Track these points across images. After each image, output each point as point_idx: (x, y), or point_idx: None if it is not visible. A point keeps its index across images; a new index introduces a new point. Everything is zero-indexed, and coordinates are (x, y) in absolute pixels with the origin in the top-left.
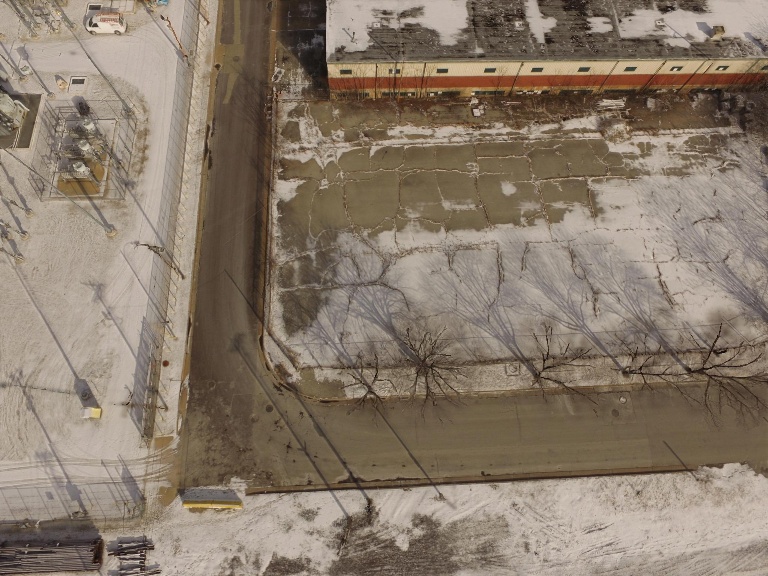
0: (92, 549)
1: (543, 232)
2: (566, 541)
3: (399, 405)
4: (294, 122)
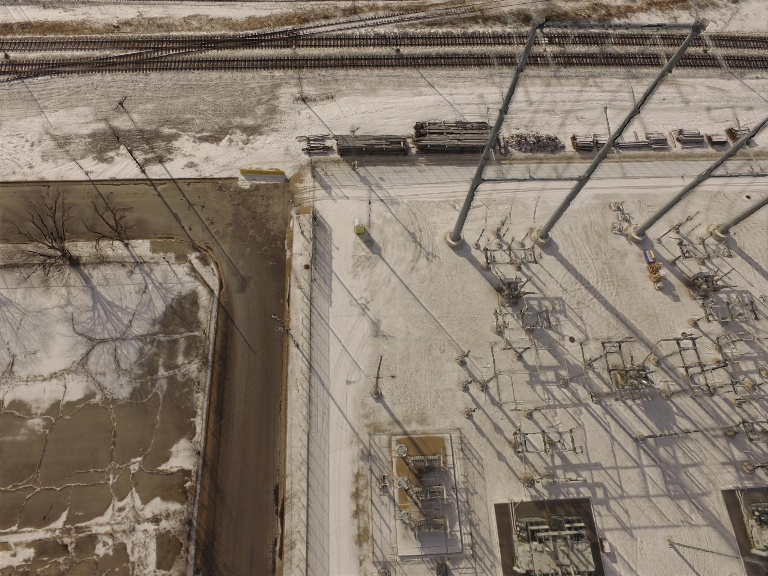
0: (339, 146)
1: None
2: (1, 147)
3: (105, 234)
4: (162, 568)
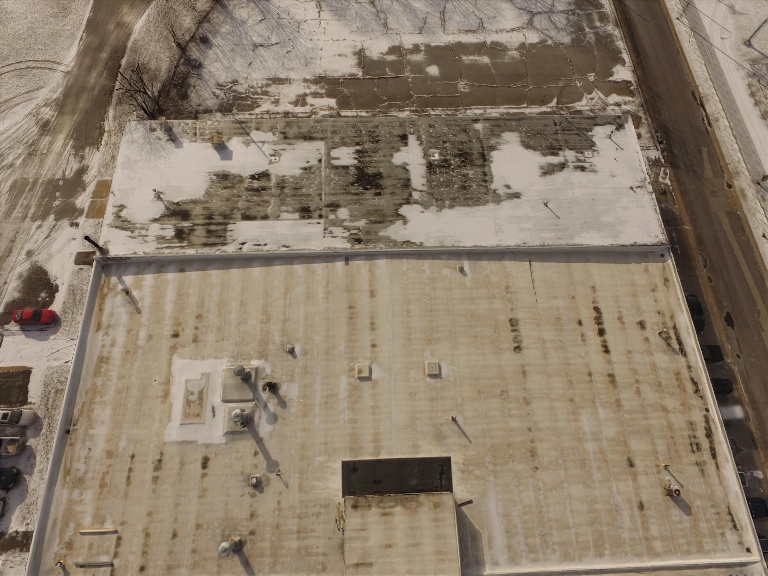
0: None
1: (407, 39)
2: None
3: None
4: None
